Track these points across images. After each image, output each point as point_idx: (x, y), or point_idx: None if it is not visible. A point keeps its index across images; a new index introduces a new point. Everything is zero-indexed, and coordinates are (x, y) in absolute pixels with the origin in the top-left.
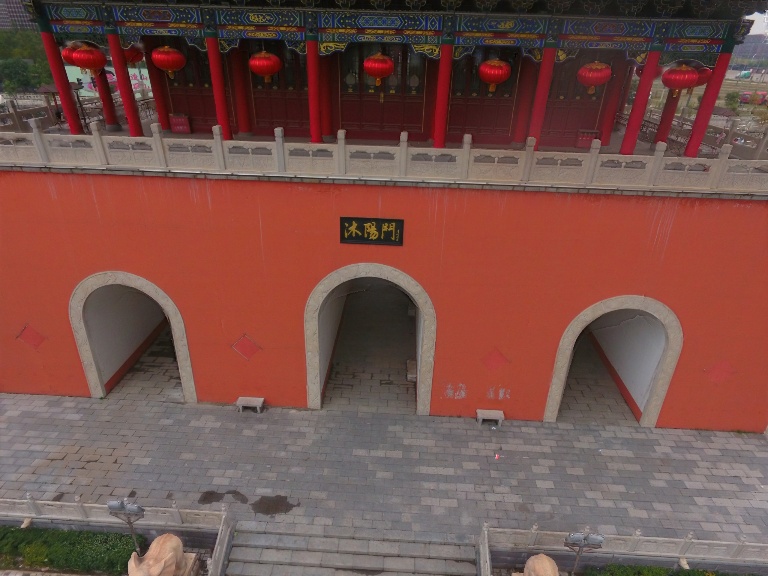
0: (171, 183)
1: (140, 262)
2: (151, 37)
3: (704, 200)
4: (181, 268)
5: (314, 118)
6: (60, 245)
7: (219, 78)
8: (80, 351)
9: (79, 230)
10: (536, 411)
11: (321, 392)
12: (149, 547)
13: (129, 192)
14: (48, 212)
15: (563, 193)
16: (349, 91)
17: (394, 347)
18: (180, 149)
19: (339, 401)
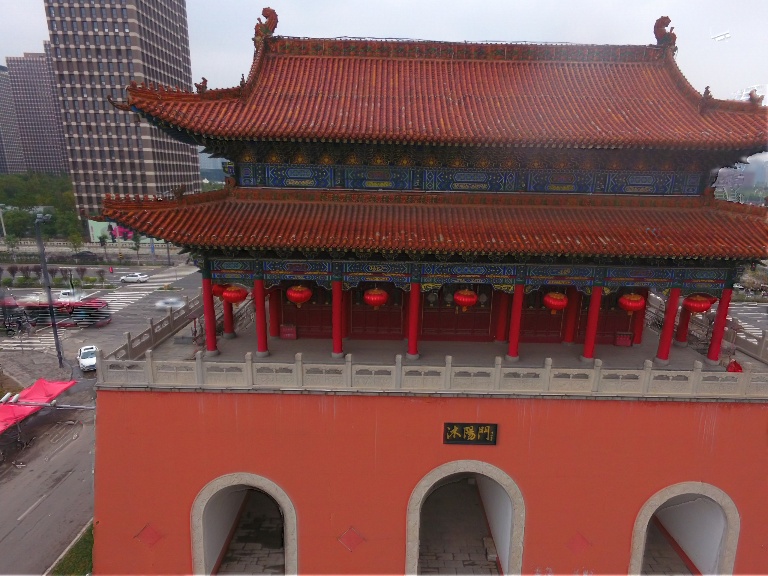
0: (304, 399)
1: (265, 464)
2: (289, 281)
3: (737, 404)
4: (301, 468)
5: (413, 336)
6: (196, 451)
7: (339, 308)
8: (193, 548)
9: (217, 438)
10: None
11: None
12: None
13: (267, 406)
14: (192, 424)
15: (626, 401)
16: (430, 306)
17: (465, 521)
18: (315, 372)
19: None
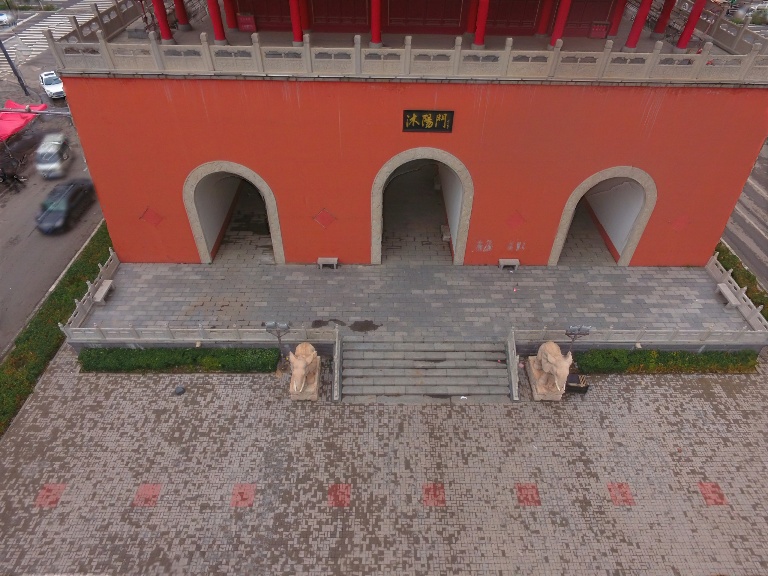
0: (267, 85)
1: (240, 153)
2: None
3: (686, 89)
4: (274, 156)
5: (375, 20)
6: (174, 140)
7: None
8: (192, 227)
9: (191, 127)
10: (543, 258)
11: (380, 251)
12: (296, 350)
13: (232, 94)
14: (164, 113)
15: (580, 86)
16: None
17: (428, 216)
18: (274, 55)
19: (393, 258)
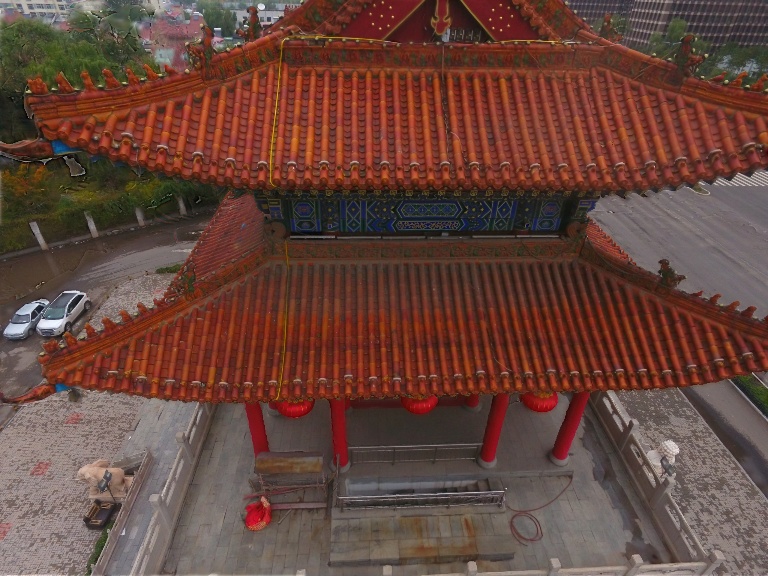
0: None
1: None
2: None
3: None
4: None
5: None
6: None
7: None
8: None
9: None
10: None
11: None
12: None
13: None
14: None
15: None
16: None
17: None
18: None
19: None
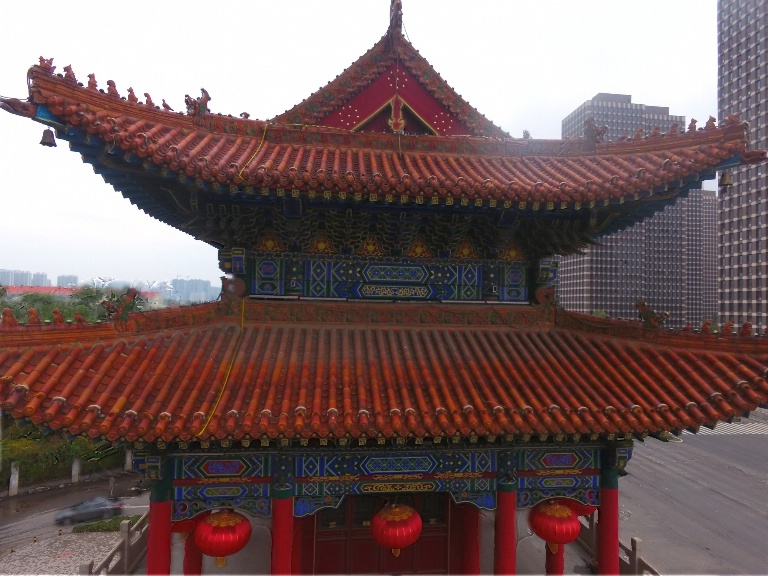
0: None
1: None
2: None
3: None
4: None
5: None
6: None
7: None
8: None
9: None
10: None
11: None
12: None
13: None
14: None
15: None
16: None
17: None
18: None
19: None
